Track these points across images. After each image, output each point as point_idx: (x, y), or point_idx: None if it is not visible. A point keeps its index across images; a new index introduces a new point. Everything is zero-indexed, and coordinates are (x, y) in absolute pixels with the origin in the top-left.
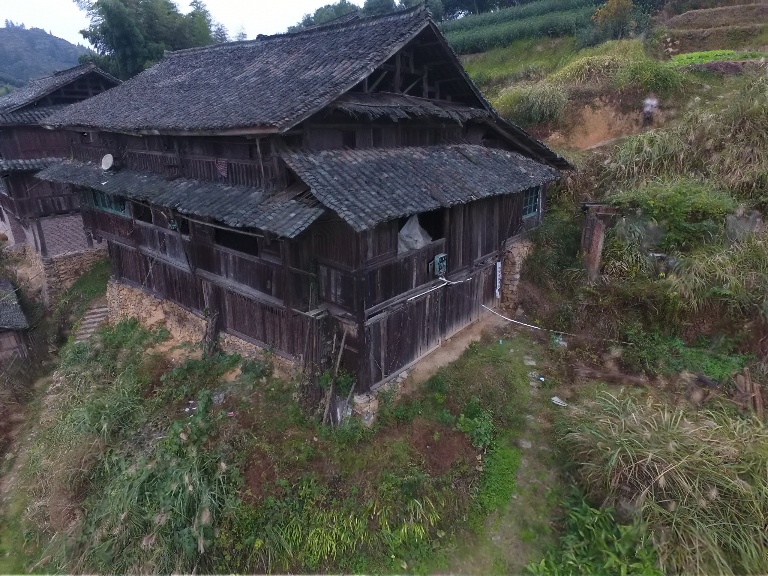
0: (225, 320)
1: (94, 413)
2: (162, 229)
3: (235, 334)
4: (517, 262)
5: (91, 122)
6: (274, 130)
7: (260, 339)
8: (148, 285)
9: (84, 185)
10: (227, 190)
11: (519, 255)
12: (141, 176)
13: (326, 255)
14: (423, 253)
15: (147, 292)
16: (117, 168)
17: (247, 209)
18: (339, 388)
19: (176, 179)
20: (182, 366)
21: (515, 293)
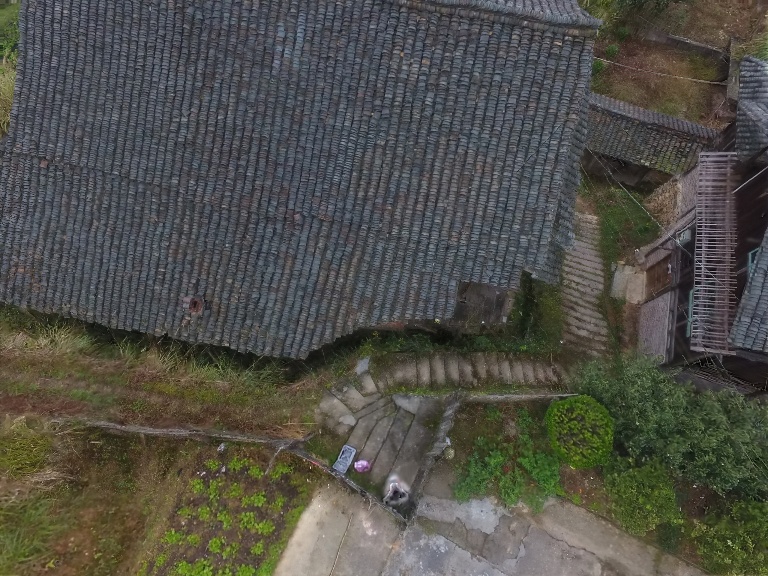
0: None
1: None
2: None
3: None
4: None
5: None
6: None
7: None
8: None
9: None
10: None
11: None
12: None
13: None
14: None
15: None
16: None
17: None
18: None
19: None
20: None
21: None
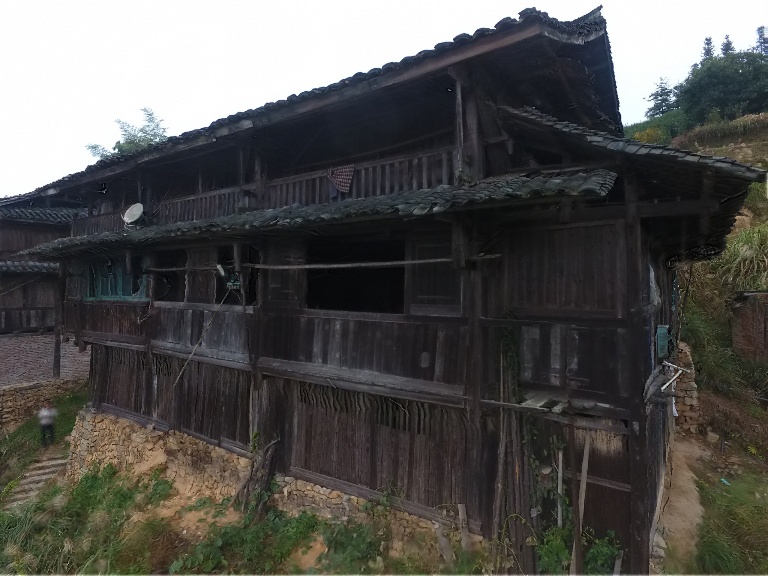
0: (289, 452)
1: None
2: (201, 305)
3: (306, 476)
4: (692, 363)
5: None
6: (527, 32)
7: (361, 481)
8: (145, 410)
9: (94, 239)
10: (361, 199)
11: (689, 354)
12: (187, 222)
13: (539, 300)
14: (653, 316)
15: (141, 422)
16: (146, 222)
17: (435, 195)
18: (585, 573)
19: (253, 211)
20: (212, 540)
21: (697, 409)
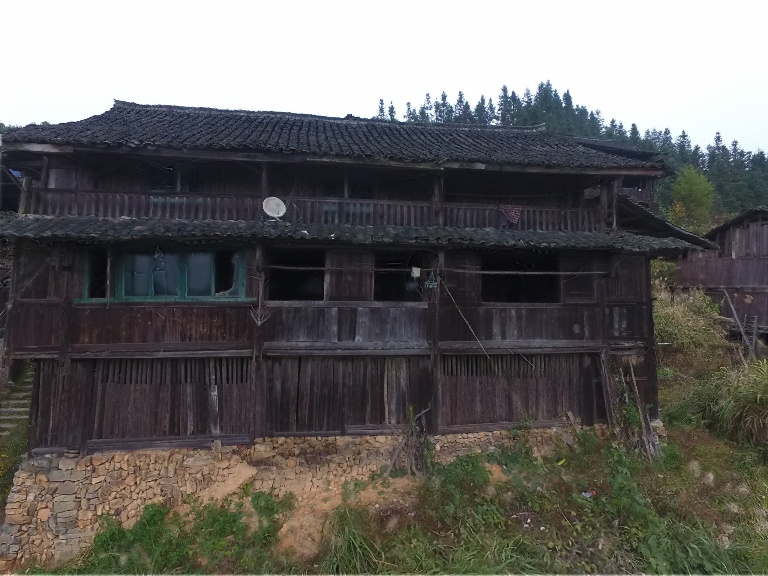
0: (436, 416)
1: (497, 575)
2: (355, 303)
3: (454, 430)
4: None
5: (283, 147)
6: (658, 172)
7: (502, 419)
8: (198, 429)
9: (265, 234)
10: (547, 232)
11: None
12: (360, 226)
13: (608, 294)
14: None
15: (191, 444)
16: None
17: None
18: None
19: (445, 226)
20: None
21: None
